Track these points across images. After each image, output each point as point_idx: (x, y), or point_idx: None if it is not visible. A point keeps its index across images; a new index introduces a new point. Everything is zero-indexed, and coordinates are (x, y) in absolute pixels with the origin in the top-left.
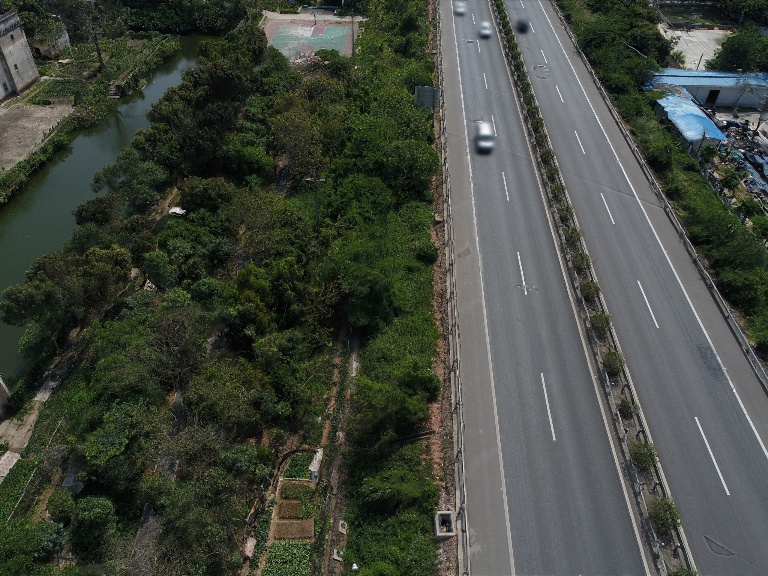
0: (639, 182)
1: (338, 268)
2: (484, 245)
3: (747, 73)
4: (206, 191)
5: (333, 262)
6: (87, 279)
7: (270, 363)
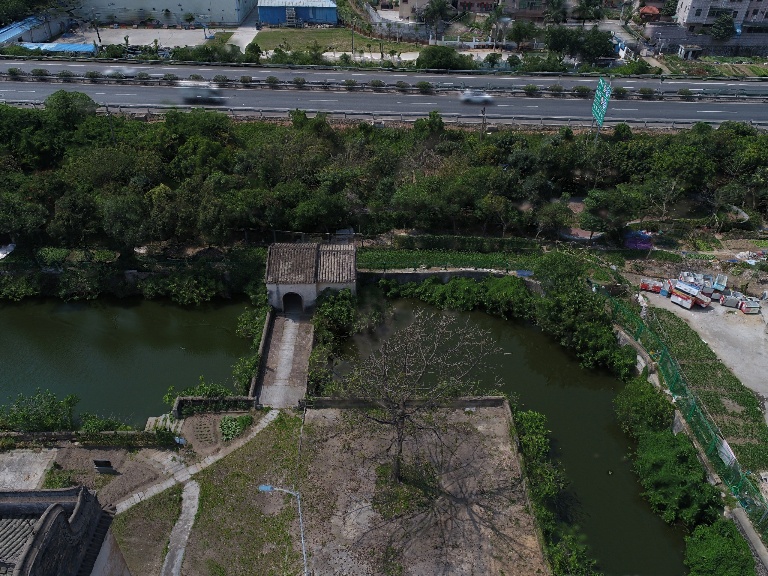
0: (137, 65)
1: (209, 125)
2: (185, 104)
3: (9, 24)
4: (50, 184)
5: (203, 124)
6: None
7: (277, 159)
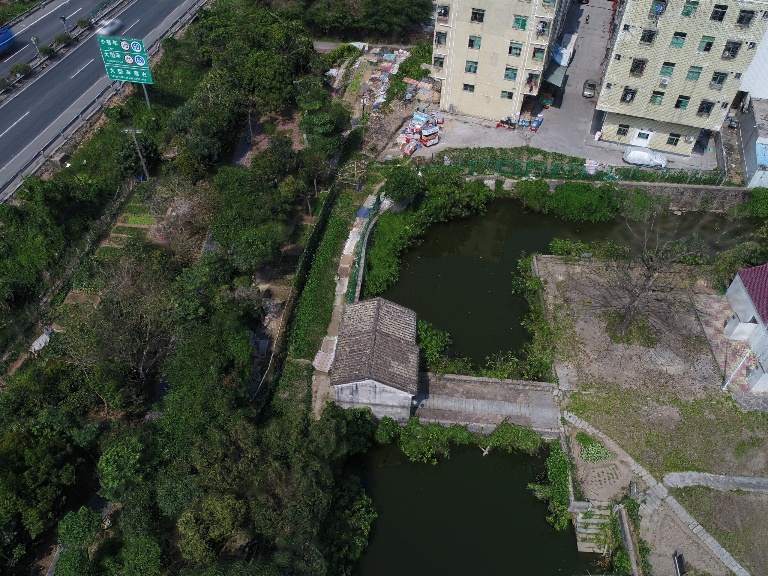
0: None
1: None
2: None
3: None
4: None
5: None
6: (225, 435)
7: None
